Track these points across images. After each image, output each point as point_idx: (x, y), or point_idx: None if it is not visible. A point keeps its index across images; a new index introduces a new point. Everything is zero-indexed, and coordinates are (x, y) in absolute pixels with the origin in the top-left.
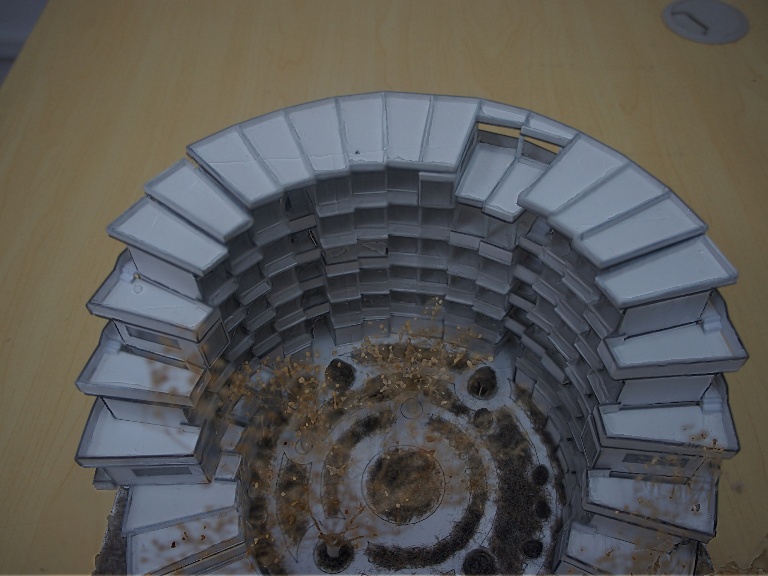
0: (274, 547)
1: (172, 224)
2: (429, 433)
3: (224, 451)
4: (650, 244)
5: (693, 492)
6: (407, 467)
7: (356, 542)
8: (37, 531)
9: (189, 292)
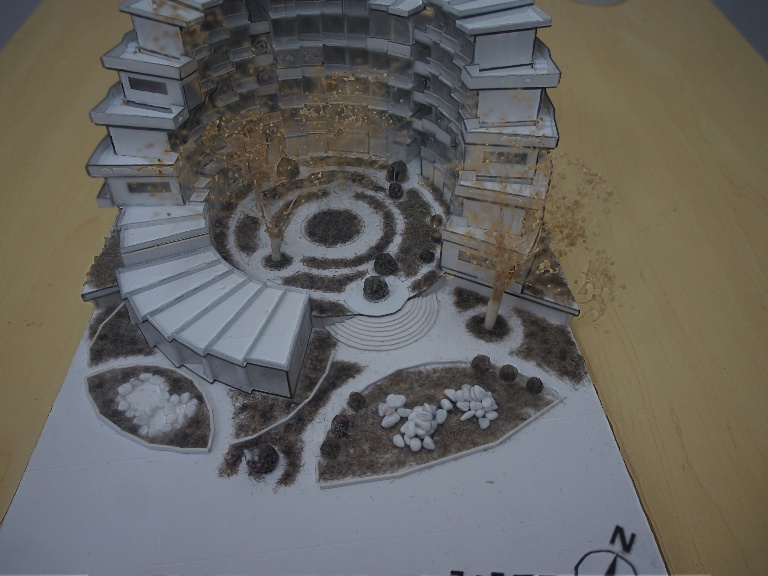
0: (232, 257)
1: (166, 7)
2: (354, 201)
3: (196, 188)
4: (494, 4)
5: (535, 188)
6: (336, 218)
7: (294, 256)
8: (47, 265)
9: (176, 53)
